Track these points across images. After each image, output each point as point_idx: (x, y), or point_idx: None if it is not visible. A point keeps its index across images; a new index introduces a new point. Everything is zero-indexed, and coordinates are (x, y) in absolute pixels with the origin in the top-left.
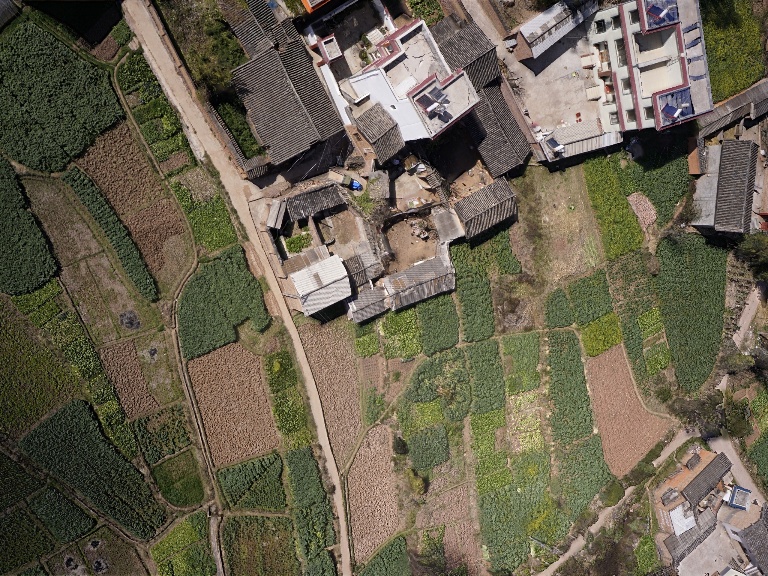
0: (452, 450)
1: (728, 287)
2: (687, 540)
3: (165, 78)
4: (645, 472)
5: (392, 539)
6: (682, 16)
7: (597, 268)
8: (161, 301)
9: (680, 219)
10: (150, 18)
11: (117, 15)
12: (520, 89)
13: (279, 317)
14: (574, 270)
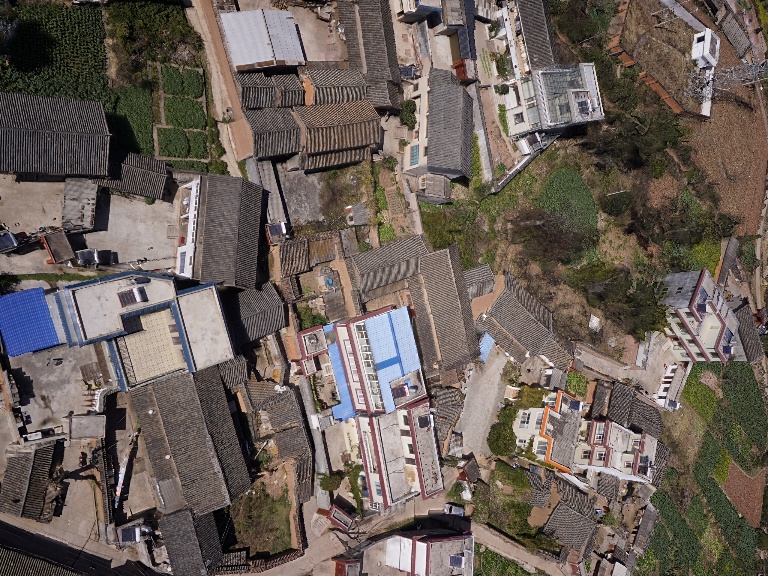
0: None
1: (754, 371)
2: None
3: (503, 551)
4: None
5: None
6: (708, 292)
7: (704, 432)
8: None
9: None
10: (483, 529)
11: None
12: (638, 383)
13: None
14: (697, 446)
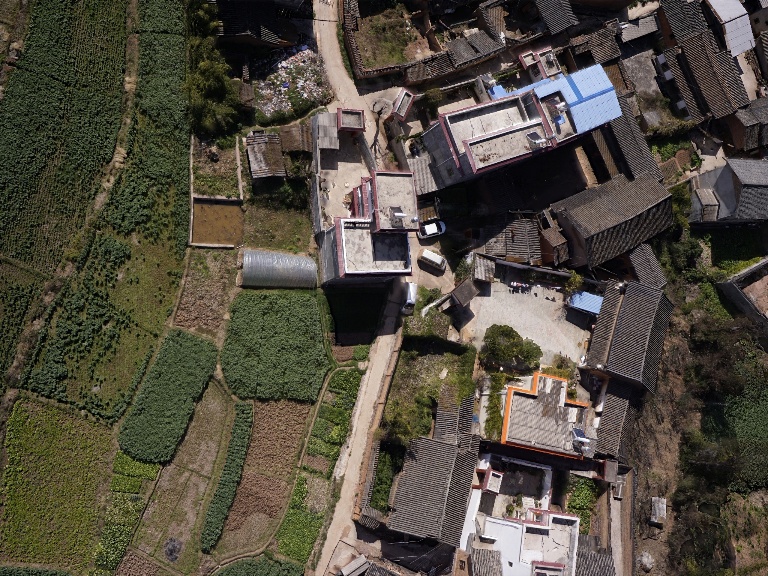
0: None
1: None
2: None
3: (363, 402)
4: None
5: None
6: None
7: None
8: (209, 556)
9: None
10: (388, 359)
11: (368, 340)
12: None
13: None
14: None
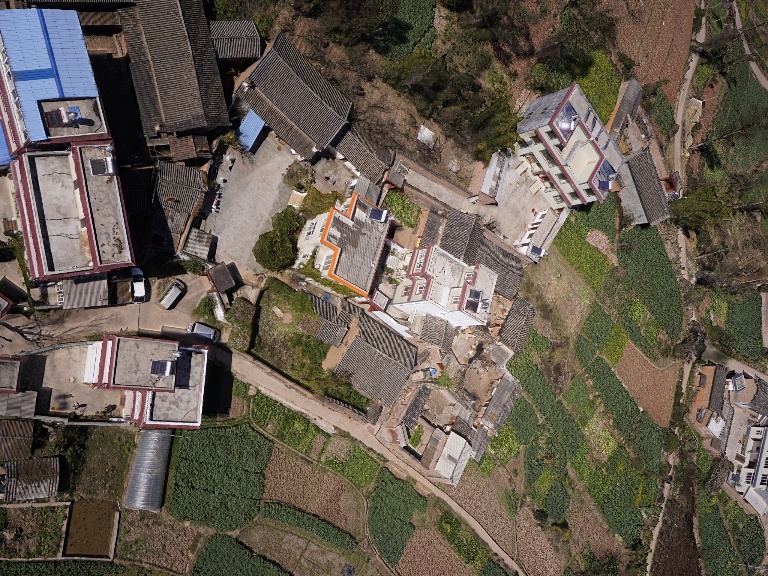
0: (569, 491)
1: (666, 246)
2: (724, 435)
3: (284, 398)
4: (682, 413)
5: (563, 574)
6: (579, 112)
7: (591, 303)
8: (360, 544)
9: (621, 227)
10: (253, 365)
11: (230, 379)
12: None
13: (431, 494)
14: (580, 316)
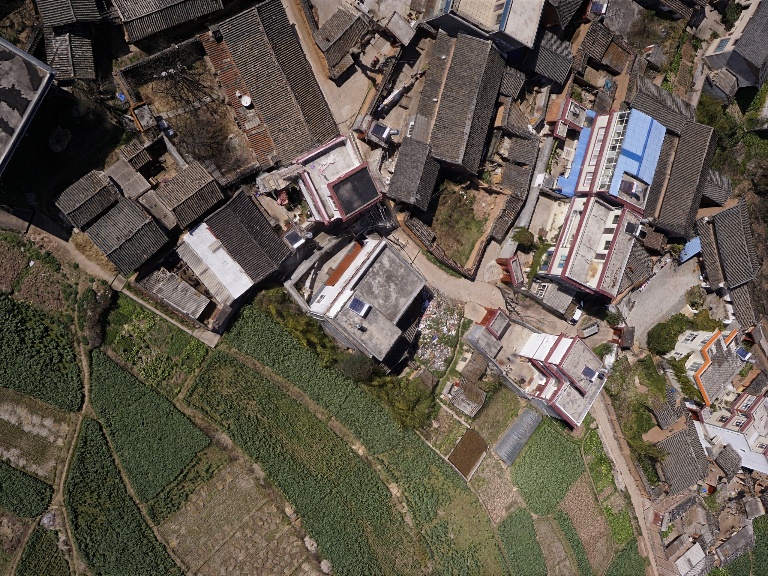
0: None
1: None
2: None
3: (608, 443)
4: None
5: None
6: None
7: None
8: None
9: None
10: (604, 408)
11: None
12: None
13: None
14: None
